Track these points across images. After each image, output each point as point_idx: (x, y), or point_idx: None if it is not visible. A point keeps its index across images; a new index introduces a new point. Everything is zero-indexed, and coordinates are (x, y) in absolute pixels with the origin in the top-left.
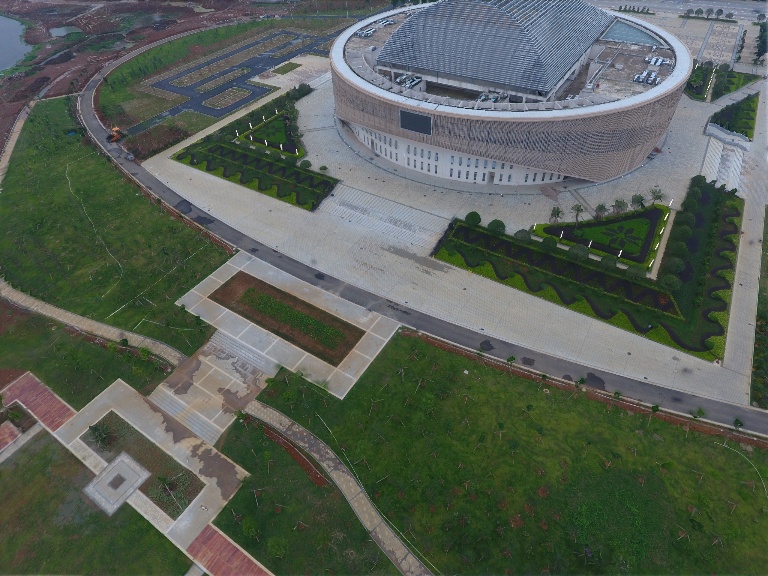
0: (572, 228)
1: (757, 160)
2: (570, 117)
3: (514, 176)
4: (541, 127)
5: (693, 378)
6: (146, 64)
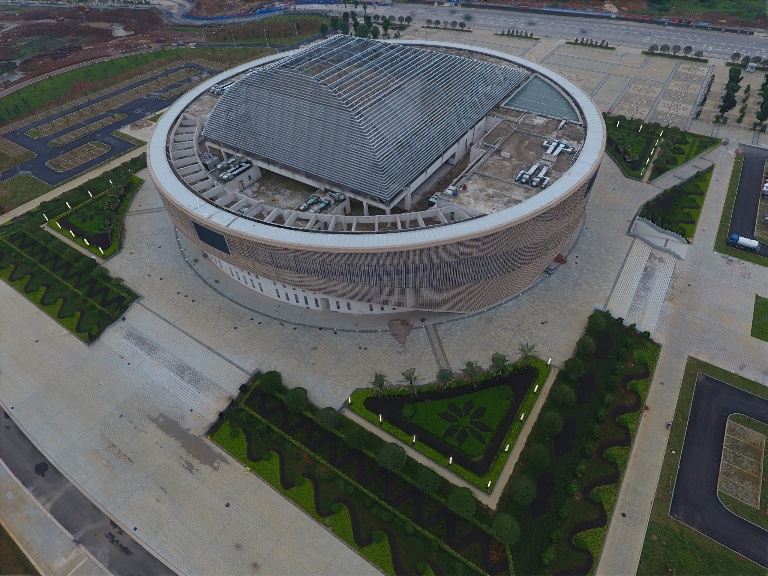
0: (404, 401)
1: (691, 275)
2: (401, 248)
3: (354, 304)
4: (362, 259)
5: None
6: (13, 105)
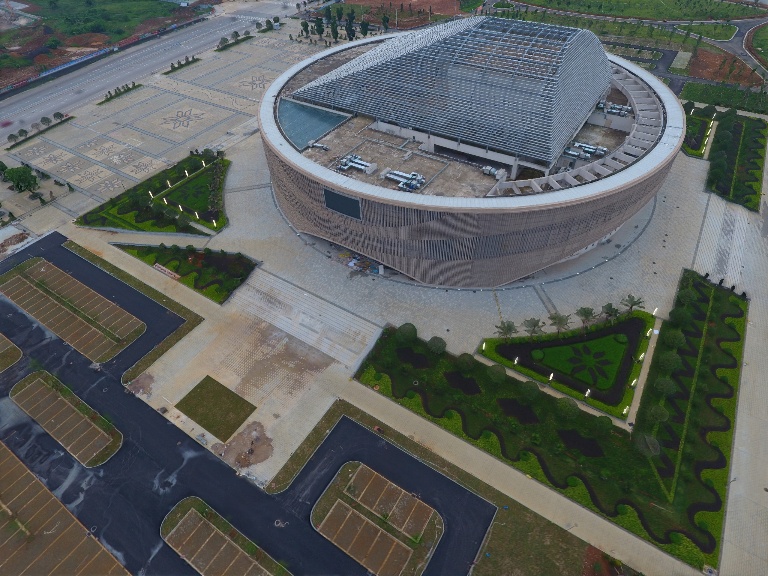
0: (686, 139)
1: None
2: None
3: None
4: None
5: None
6: None
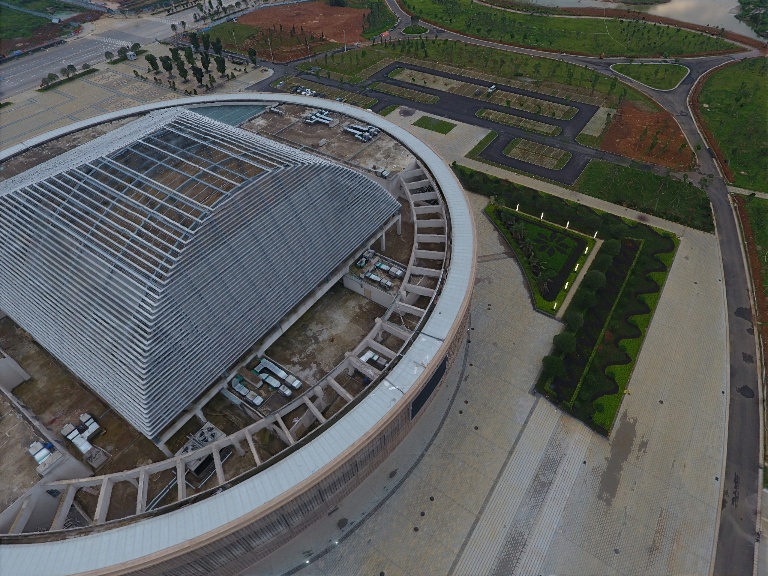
0: None
1: None
2: None
3: None
4: None
5: (704, 254)
6: None
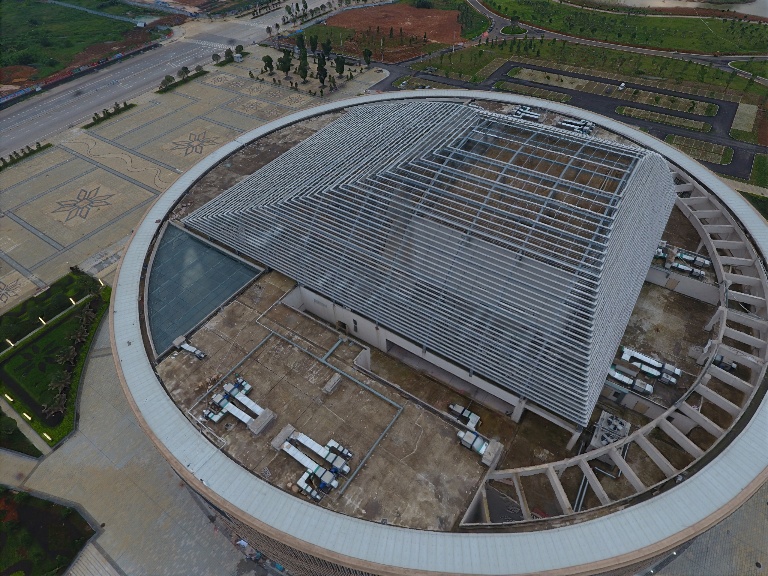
0: None
1: None
2: None
3: None
4: None
5: None
6: None
